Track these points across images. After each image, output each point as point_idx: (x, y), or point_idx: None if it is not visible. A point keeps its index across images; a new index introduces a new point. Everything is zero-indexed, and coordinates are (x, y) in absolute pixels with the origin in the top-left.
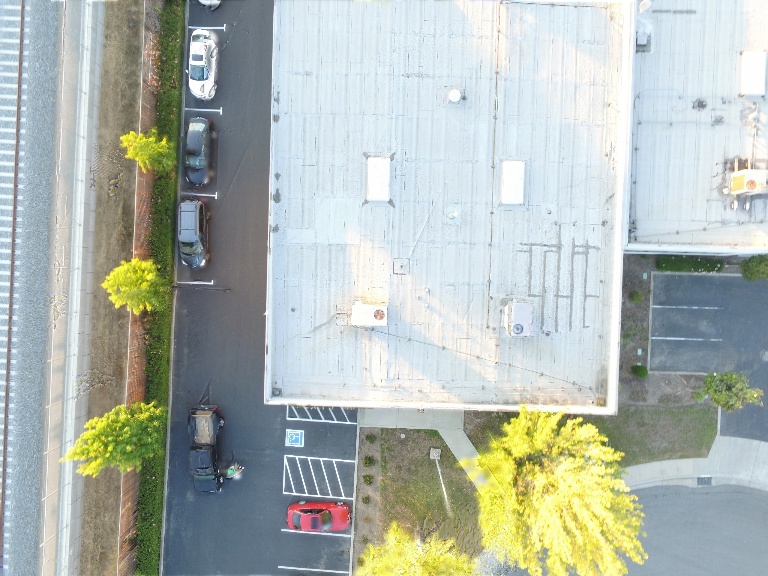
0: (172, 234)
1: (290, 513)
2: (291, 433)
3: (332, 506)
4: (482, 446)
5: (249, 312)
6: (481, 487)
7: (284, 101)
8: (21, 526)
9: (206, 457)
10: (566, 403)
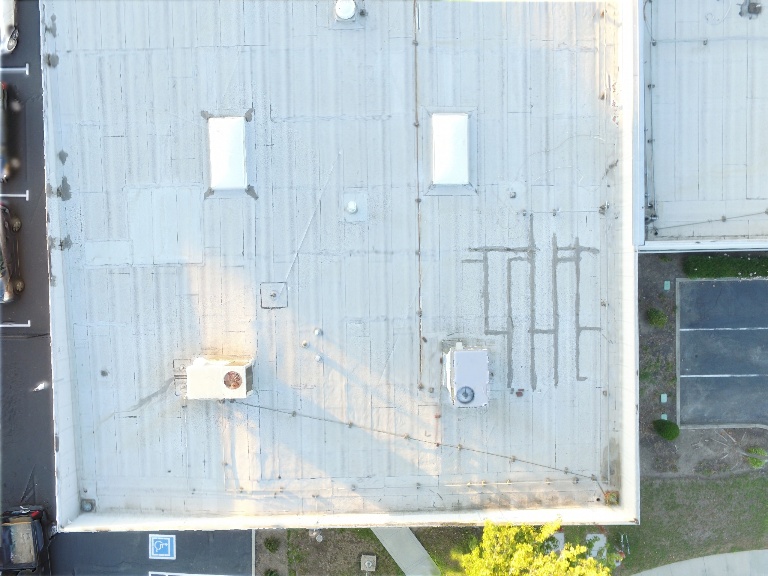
0: None
1: None
2: (157, 540)
3: None
4: (437, 548)
5: None
6: None
7: (64, 31)
8: None
9: None
10: (555, 503)
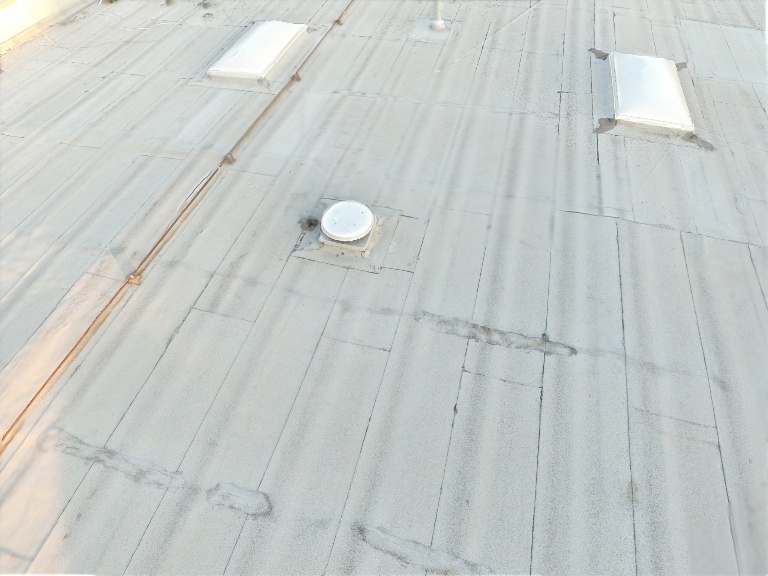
0: None
1: None
2: None
3: None
4: None
5: None
6: None
7: None
8: None
9: None
10: None
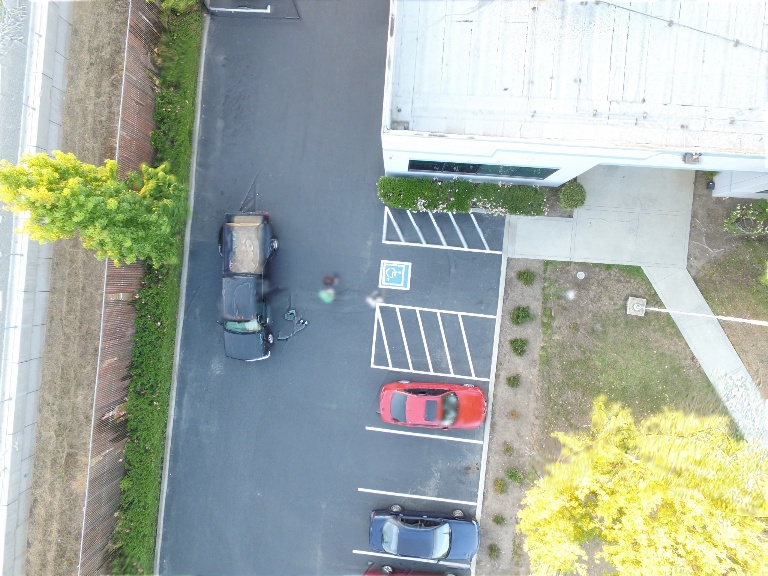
0: None
1: (387, 394)
2: (389, 266)
3: (458, 387)
4: (718, 296)
5: (328, 59)
6: (711, 368)
7: None
8: None
9: (246, 303)
10: None
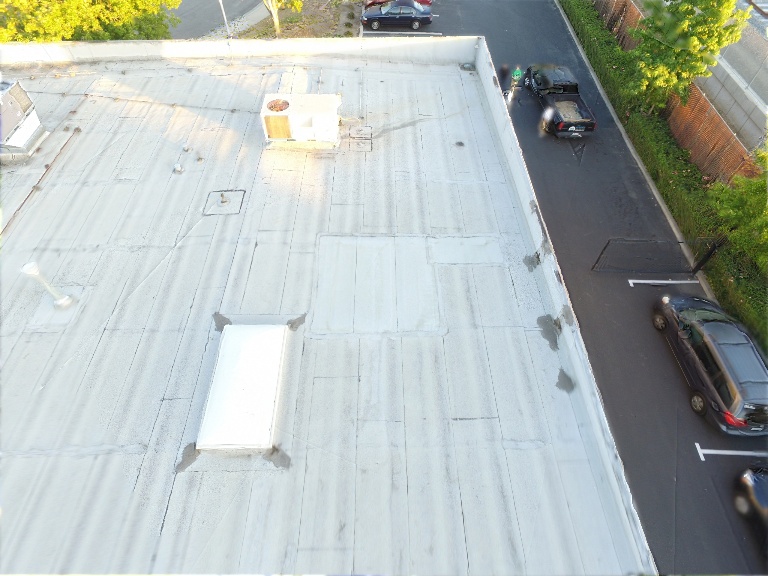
0: (760, 348)
1: None
2: None
3: None
4: None
5: None
6: None
7: None
8: (752, 27)
9: None
10: None
